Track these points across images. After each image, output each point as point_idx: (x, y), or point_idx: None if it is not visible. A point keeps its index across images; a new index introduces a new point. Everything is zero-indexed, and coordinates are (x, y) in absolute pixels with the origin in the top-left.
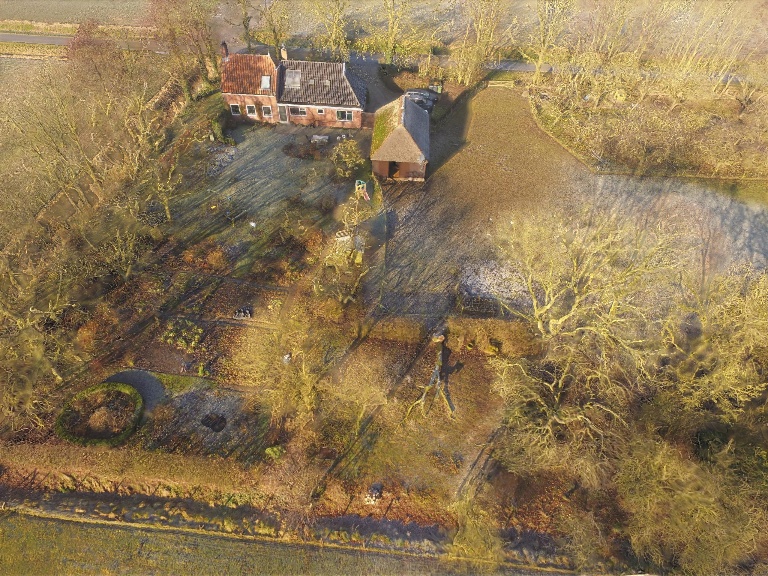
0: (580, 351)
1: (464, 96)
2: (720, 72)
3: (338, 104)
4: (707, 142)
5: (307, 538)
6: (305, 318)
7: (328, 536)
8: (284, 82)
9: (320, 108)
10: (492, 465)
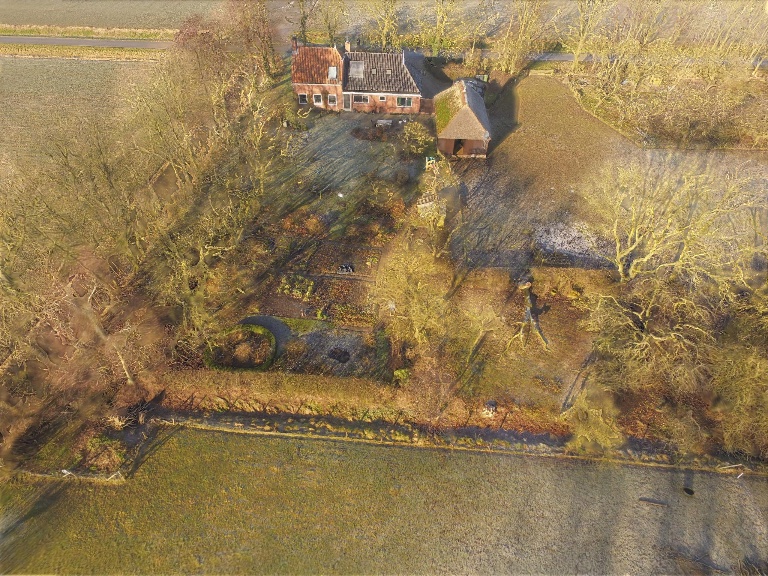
0: (666, 283)
1: (510, 83)
2: (750, 56)
3: (399, 91)
4: (747, 116)
5: (438, 443)
6: None
7: (456, 442)
8: (348, 72)
9: (382, 95)
10: (589, 386)
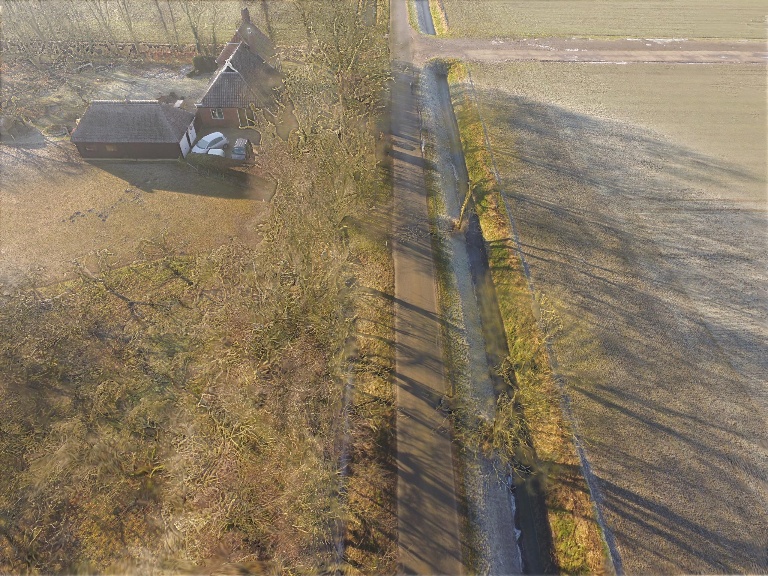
0: None
1: None
2: None
3: None
4: None
5: None
6: None
7: None
8: None
9: None
10: None
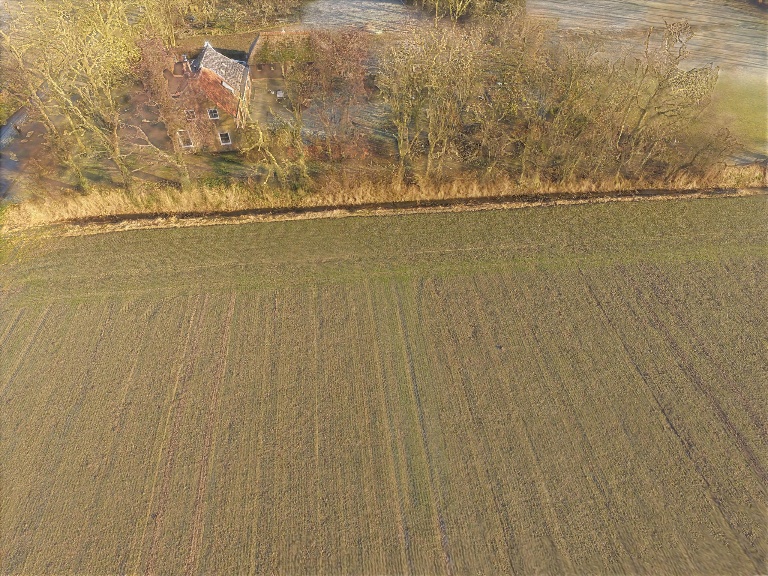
0: (478, 2)
1: None
2: None
3: (243, 74)
4: None
5: None
6: None
7: None
8: None
9: None
10: None
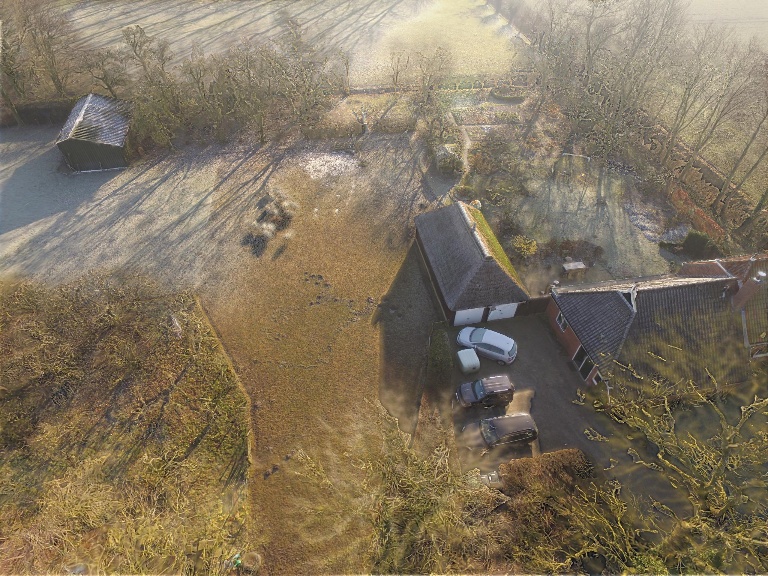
0: None
1: None
2: None
3: None
4: None
5: None
6: None
7: None
8: None
9: None
10: None
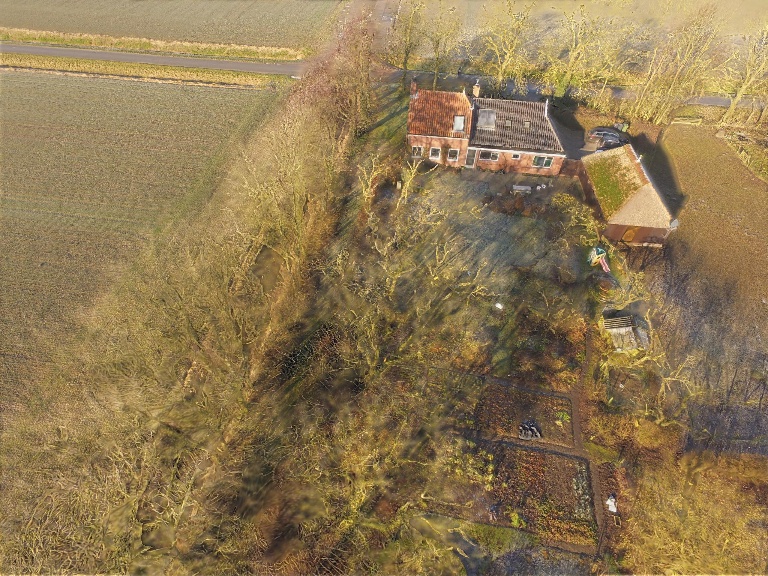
0: None
1: (657, 137)
2: None
3: (538, 149)
4: None
5: None
6: (608, 441)
7: None
8: (476, 123)
9: (517, 153)
10: None
